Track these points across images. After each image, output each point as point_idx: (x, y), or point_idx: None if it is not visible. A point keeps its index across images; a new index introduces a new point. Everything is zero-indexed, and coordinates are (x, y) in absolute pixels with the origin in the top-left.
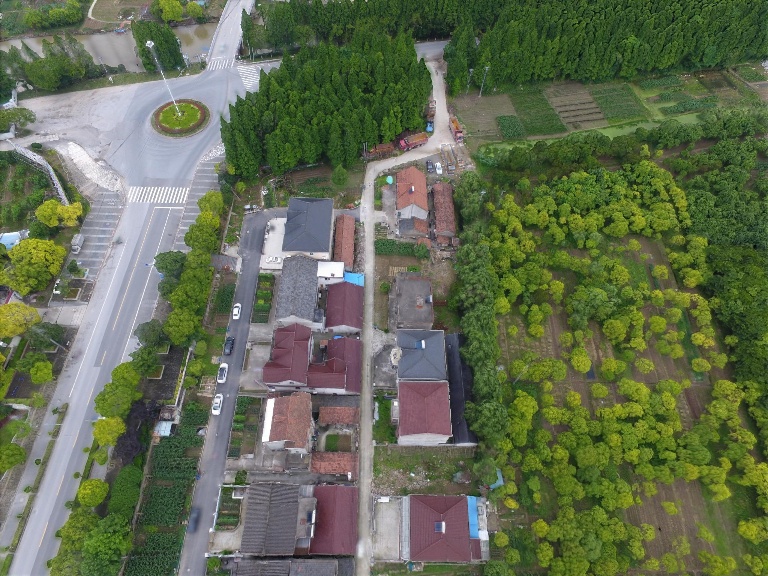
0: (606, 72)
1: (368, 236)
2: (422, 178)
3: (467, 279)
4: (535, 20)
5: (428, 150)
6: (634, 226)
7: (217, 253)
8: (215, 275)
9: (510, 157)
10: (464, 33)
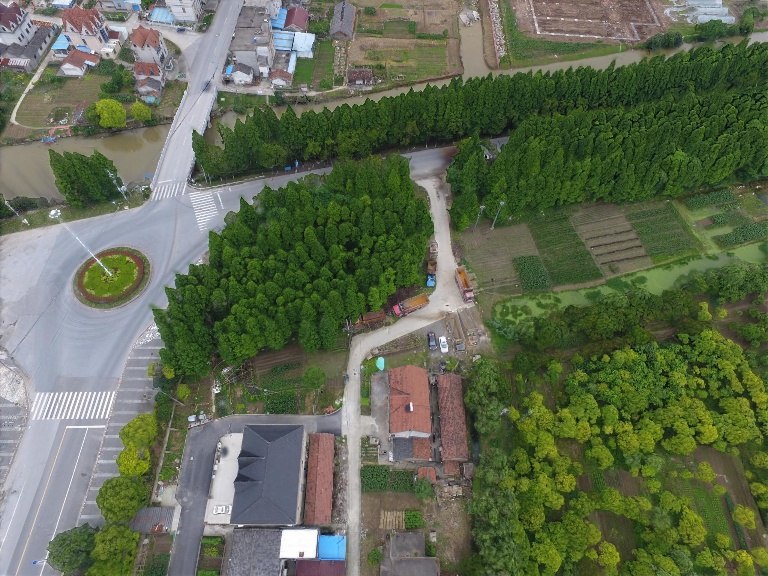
0: (647, 193)
1: (352, 460)
2: (423, 378)
3: (488, 558)
4: (560, 136)
5: (429, 314)
6: (703, 439)
7: (145, 506)
8: (141, 542)
9: (536, 334)
10: (473, 158)
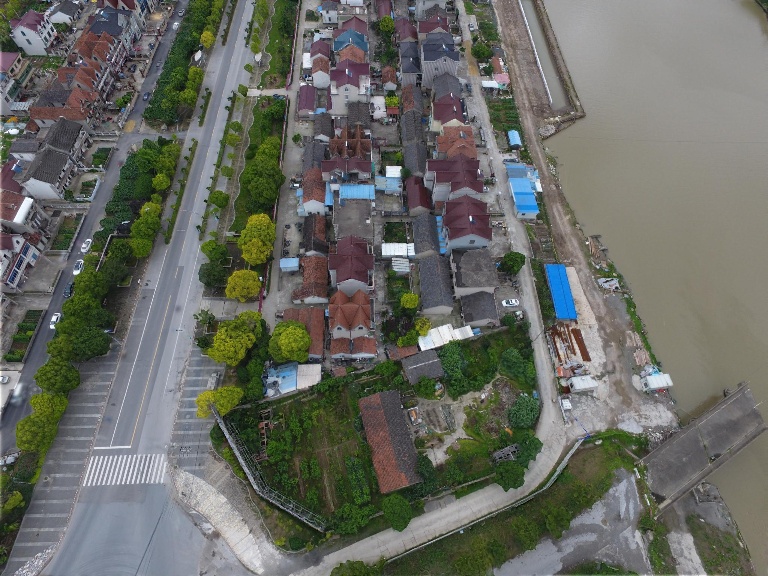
0: None
1: None
2: None
3: None
4: None
5: None
6: None
7: None
8: None
9: None
10: None
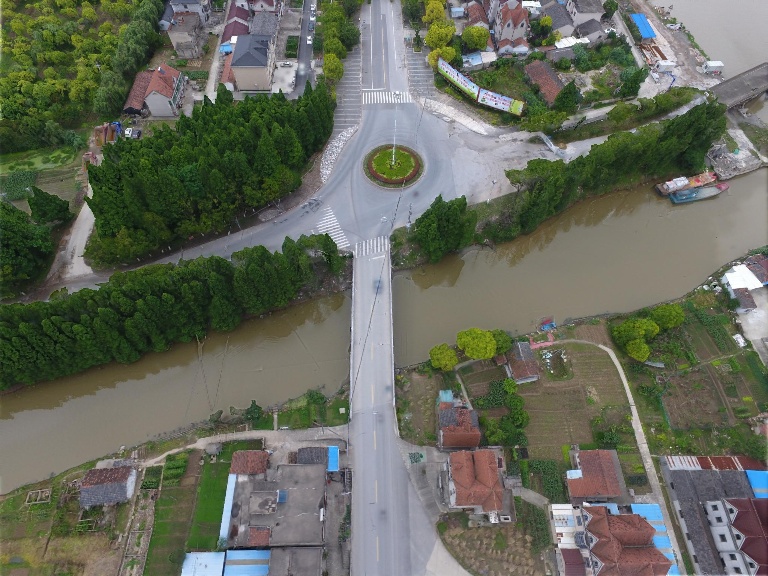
0: None
1: (212, 83)
2: None
3: None
4: None
5: None
6: None
7: None
8: None
9: None
10: (4, 215)
